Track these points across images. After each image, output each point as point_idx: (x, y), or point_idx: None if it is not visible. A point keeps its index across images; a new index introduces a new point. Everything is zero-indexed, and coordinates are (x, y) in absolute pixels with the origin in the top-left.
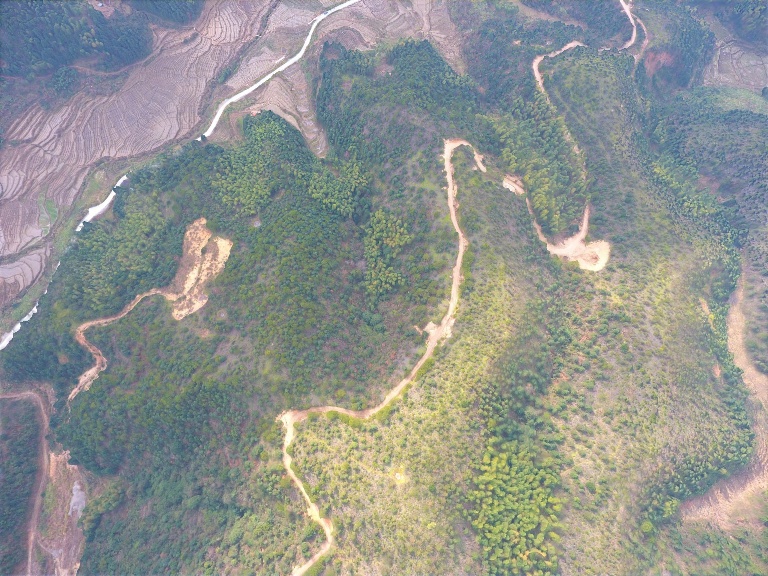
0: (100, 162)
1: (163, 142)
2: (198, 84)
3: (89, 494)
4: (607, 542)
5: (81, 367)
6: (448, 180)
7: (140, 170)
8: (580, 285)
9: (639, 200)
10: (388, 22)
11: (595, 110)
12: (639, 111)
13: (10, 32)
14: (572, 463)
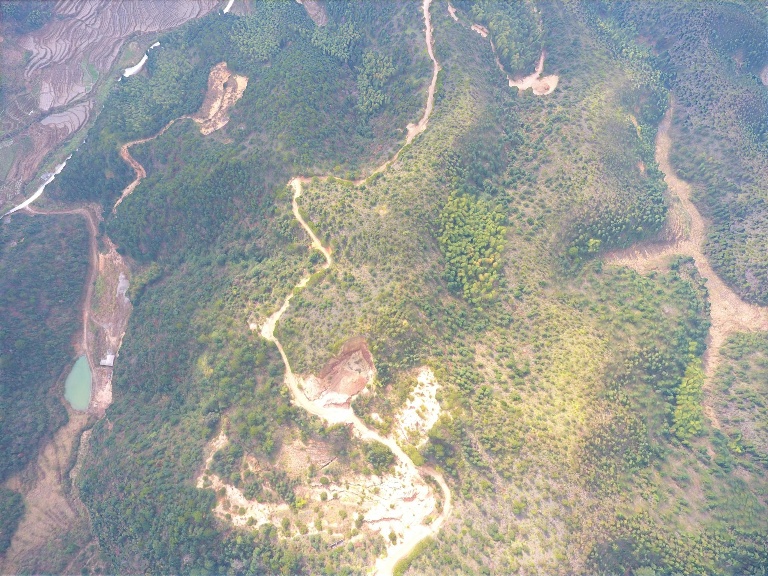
0: (133, 35)
1: (186, 20)
2: None
3: (133, 279)
4: (540, 252)
5: (124, 181)
6: (426, 25)
7: (169, 34)
8: (532, 103)
9: (584, 43)
10: None
11: None
12: None
13: None
14: (518, 211)
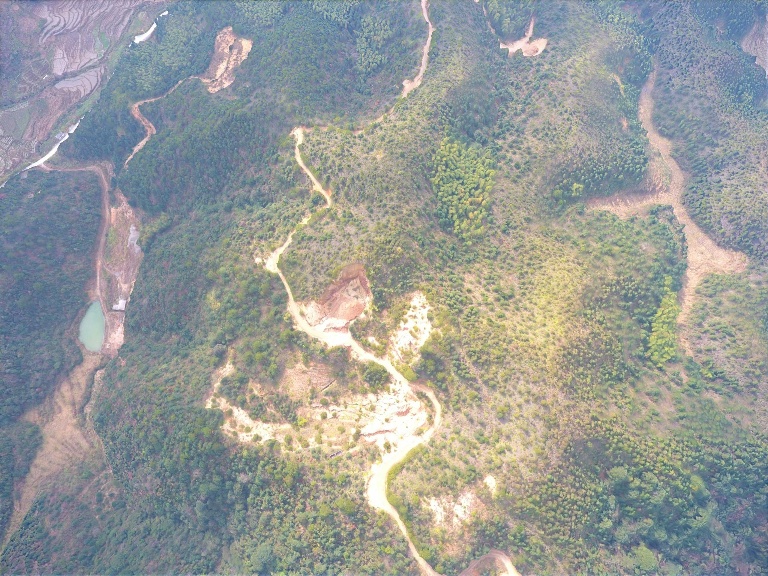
0: (142, 5)
1: None
2: None
3: None
4: (526, 193)
5: (135, 138)
6: None
7: (177, 2)
8: (522, 63)
9: (571, 8)
10: None
11: None
12: None
13: None
14: (506, 157)
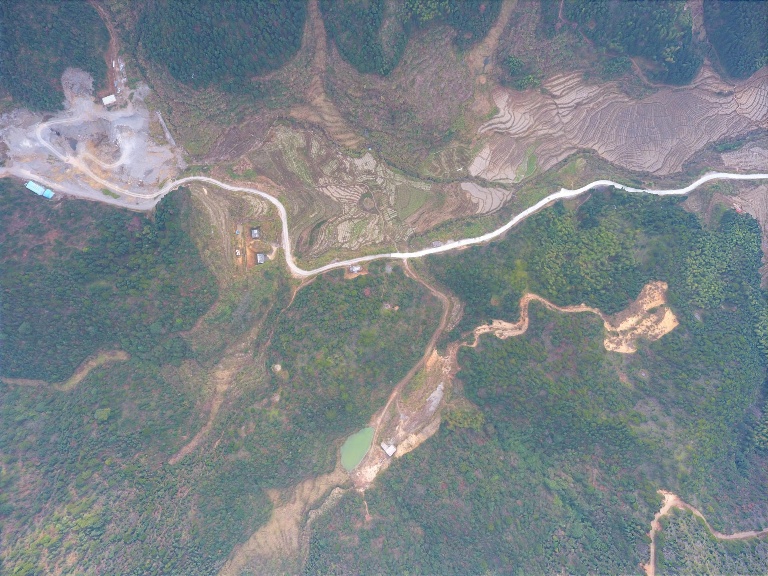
0: (588, 151)
1: (642, 169)
2: (701, 139)
3: (449, 399)
4: None
5: (503, 316)
6: None
7: (629, 194)
8: None
9: None
10: None
11: None
12: None
13: (623, 6)
14: None
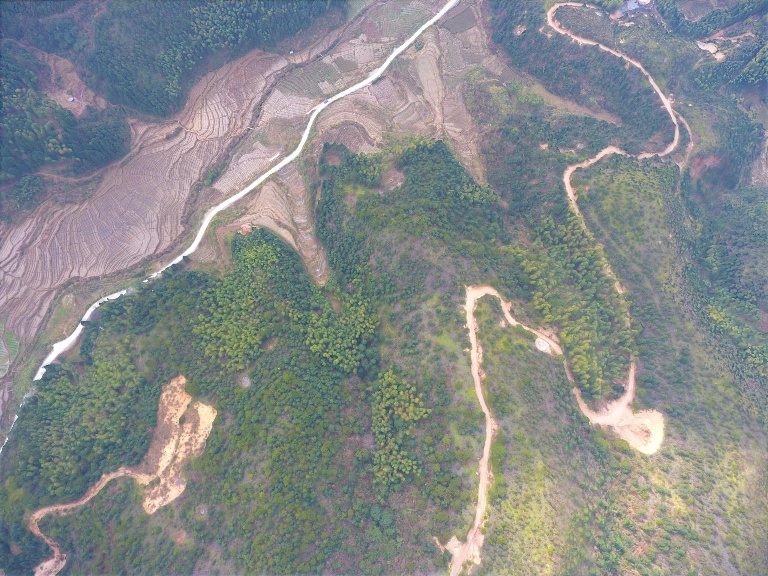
0: (68, 283)
1: (141, 258)
2: (182, 187)
3: None
4: None
5: (37, 558)
6: (471, 339)
7: (112, 303)
8: (631, 476)
9: (697, 360)
10: (396, 112)
11: (640, 241)
12: (689, 237)
13: None
14: None
